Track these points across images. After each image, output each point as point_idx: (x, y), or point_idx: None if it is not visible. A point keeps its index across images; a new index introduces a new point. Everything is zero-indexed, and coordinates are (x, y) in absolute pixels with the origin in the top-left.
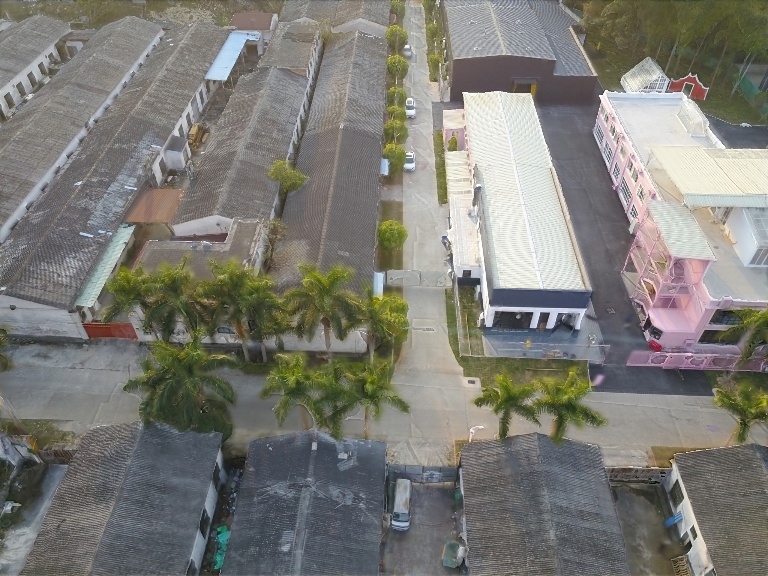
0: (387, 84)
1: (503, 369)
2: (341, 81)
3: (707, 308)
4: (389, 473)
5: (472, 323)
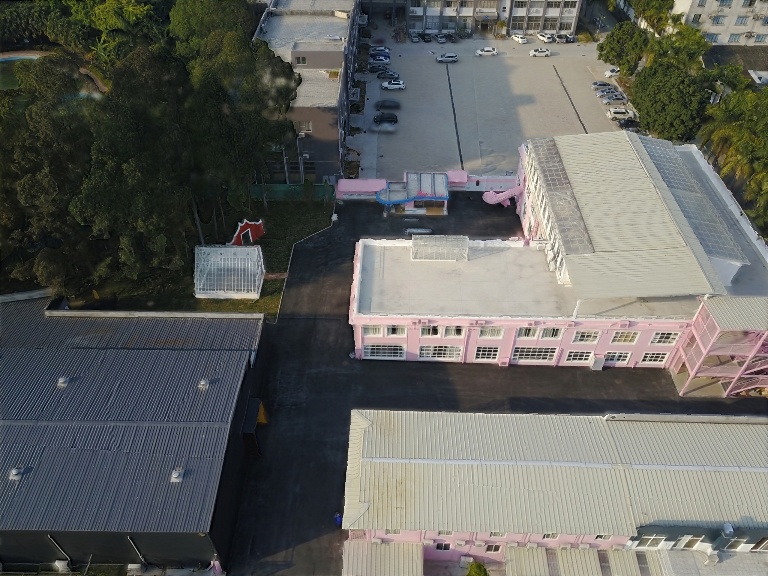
0: None
1: None
2: None
3: None
4: None
5: None
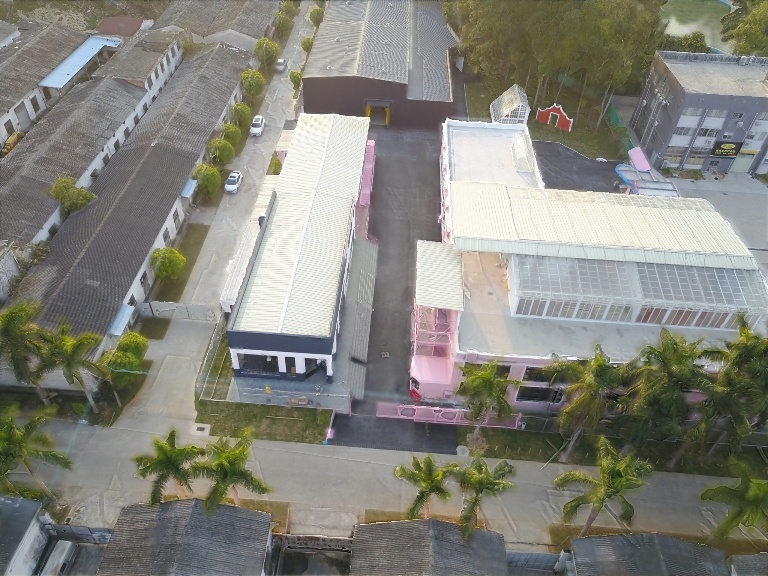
0: (247, 99)
1: (240, 416)
2: (179, 95)
3: (453, 360)
4: (57, 532)
5: (228, 363)
